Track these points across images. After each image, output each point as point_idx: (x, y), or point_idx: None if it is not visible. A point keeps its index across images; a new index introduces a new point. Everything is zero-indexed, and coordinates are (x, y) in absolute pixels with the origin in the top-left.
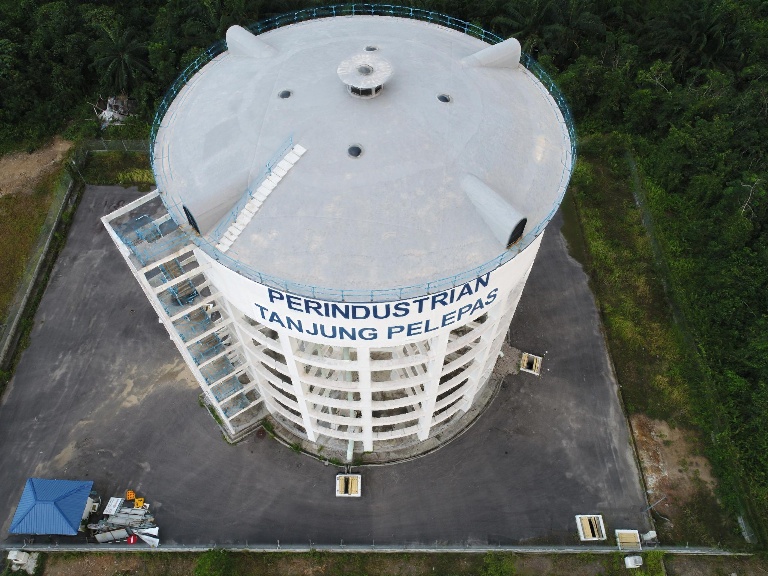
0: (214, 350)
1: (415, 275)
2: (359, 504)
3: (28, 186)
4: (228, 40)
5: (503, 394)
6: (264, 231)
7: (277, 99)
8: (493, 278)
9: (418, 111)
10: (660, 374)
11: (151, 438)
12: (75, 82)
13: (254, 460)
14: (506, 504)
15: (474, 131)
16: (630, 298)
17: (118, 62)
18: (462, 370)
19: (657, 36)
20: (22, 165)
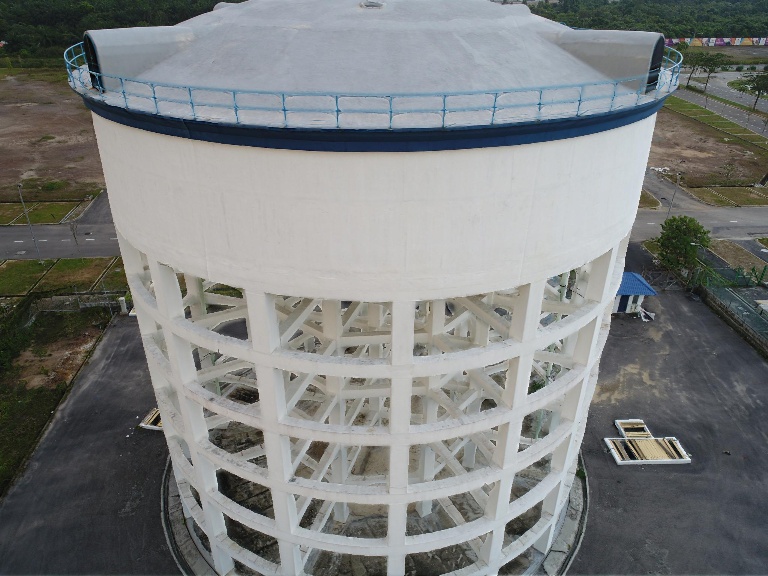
0: None
1: None
2: None
3: None
4: None
5: None
6: None
7: None
8: None
9: None
10: None
11: None
12: None
13: None
14: (238, 323)
15: None
16: None
17: None
18: None
19: None
20: None
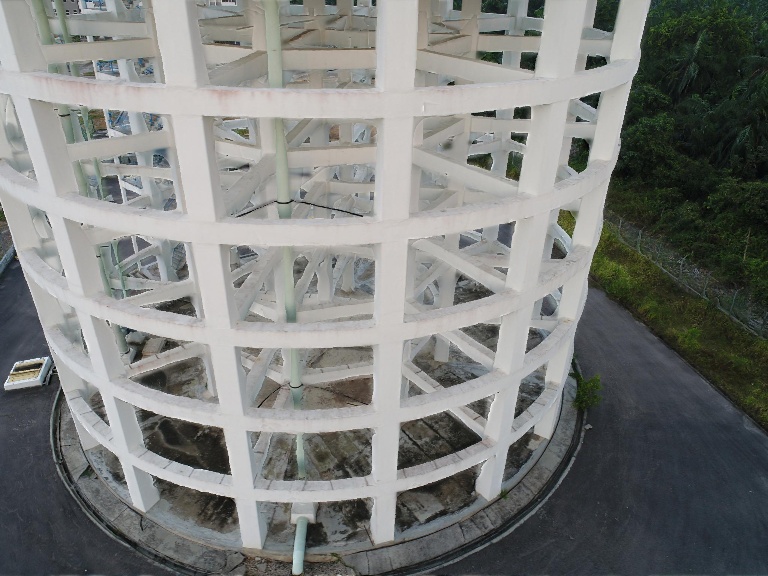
0: (119, 74)
1: None
2: None
3: None
4: None
5: None
6: None
7: None
8: None
9: None
10: None
11: None
12: None
13: None
14: None
15: None
16: None
17: None
18: None
19: None
20: None
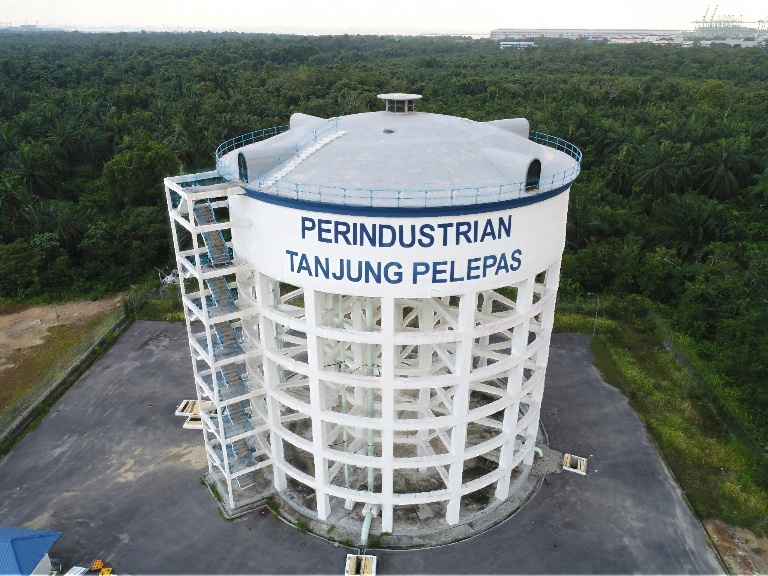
0: (234, 353)
1: (439, 196)
2: None
3: (83, 320)
4: (291, 122)
5: (546, 490)
6: (305, 172)
7: (327, 121)
8: (515, 229)
9: (443, 121)
10: (729, 482)
11: (138, 511)
12: (149, 256)
13: (251, 537)
14: None
15: (491, 134)
16: (677, 416)
17: (190, 237)
18: (496, 464)
19: (658, 234)
20: (83, 308)
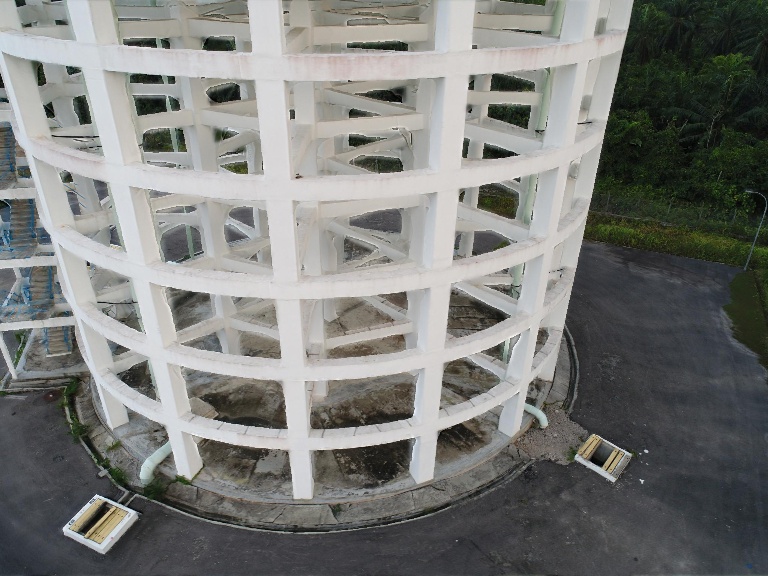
0: None
1: None
2: (89, 568)
3: None
4: None
5: (519, 487)
6: None
7: None
8: None
9: None
10: None
11: None
12: None
13: (4, 425)
14: None
15: None
16: None
17: None
18: None
19: None
20: None
